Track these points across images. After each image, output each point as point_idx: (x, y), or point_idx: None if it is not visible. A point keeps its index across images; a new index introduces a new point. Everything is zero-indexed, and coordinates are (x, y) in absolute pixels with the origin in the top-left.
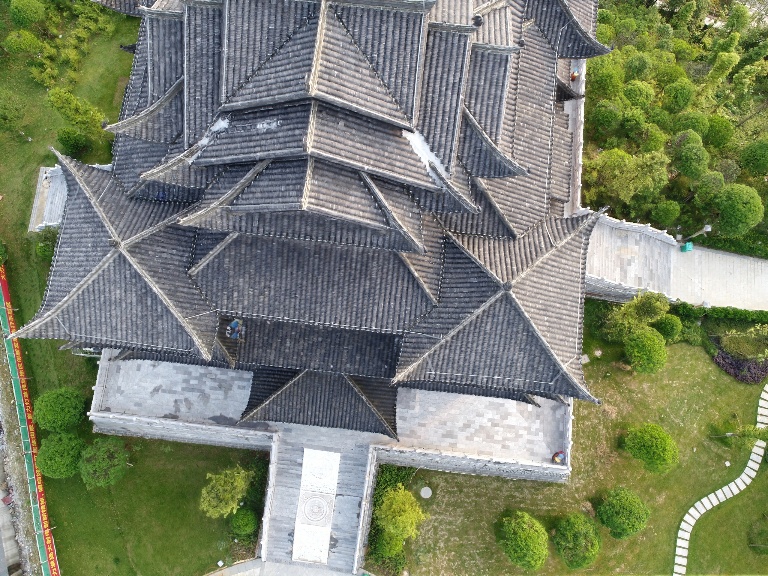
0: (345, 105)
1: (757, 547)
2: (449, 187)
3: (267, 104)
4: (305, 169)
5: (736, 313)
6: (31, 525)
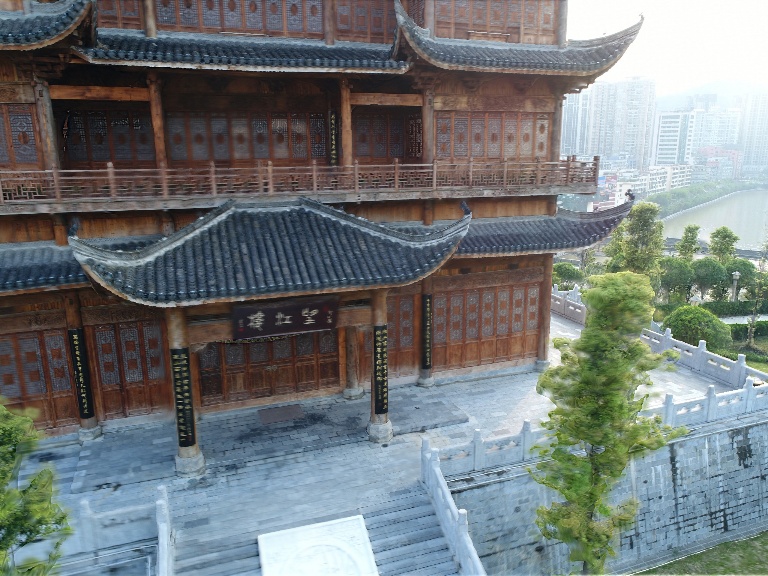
0: None
1: None
2: None
3: None
4: None
5: (733, 325)
6: None
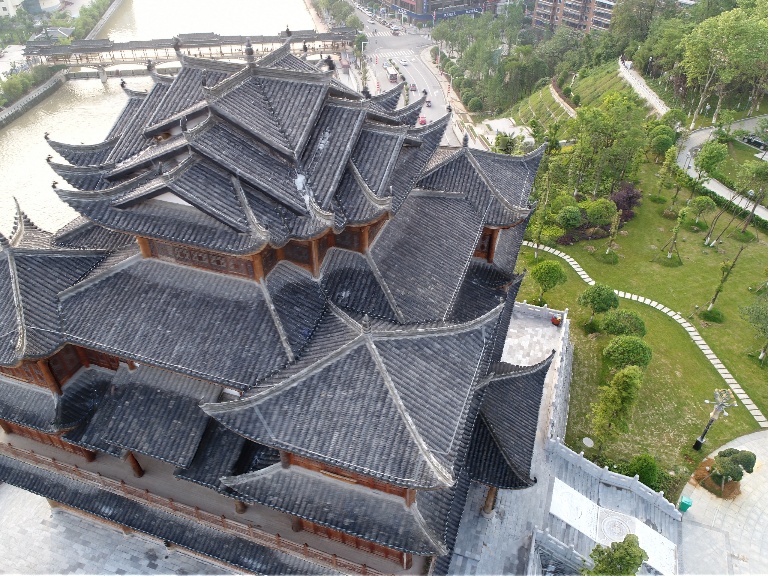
0: (338, 88)
1: (613, 260)
2: (400, 112)
3: (315, 119)
4: (371, 132)
5: None
6: None
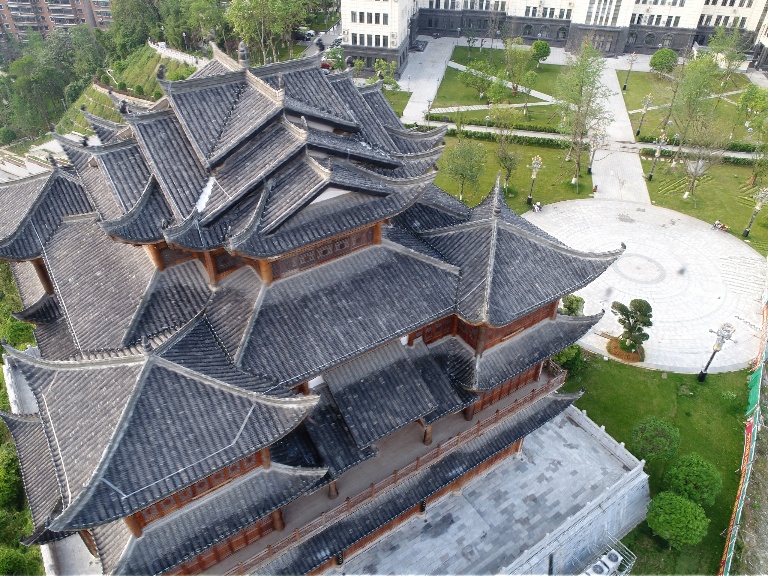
0: None
1: None
2: None
3: None
4: None
5: None
6: (762, 497)
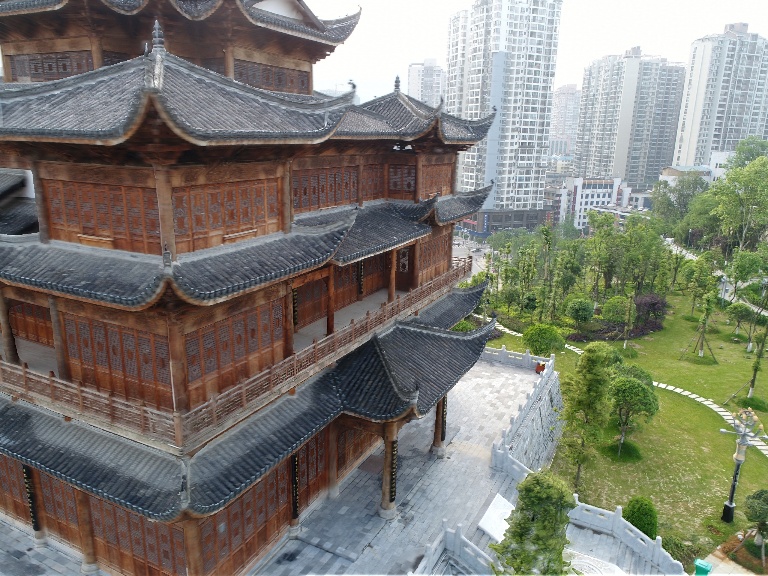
0: None
1: (631, 354)
2: None
3: None
4: None
5: None
6: None
